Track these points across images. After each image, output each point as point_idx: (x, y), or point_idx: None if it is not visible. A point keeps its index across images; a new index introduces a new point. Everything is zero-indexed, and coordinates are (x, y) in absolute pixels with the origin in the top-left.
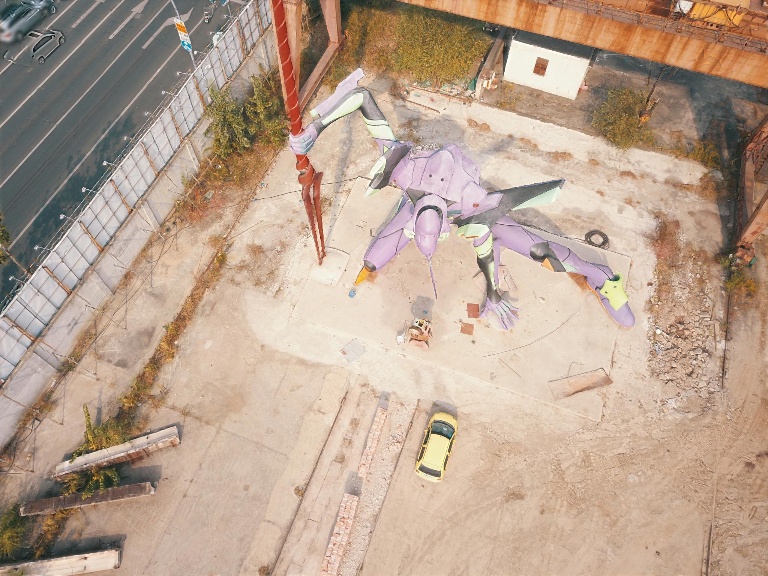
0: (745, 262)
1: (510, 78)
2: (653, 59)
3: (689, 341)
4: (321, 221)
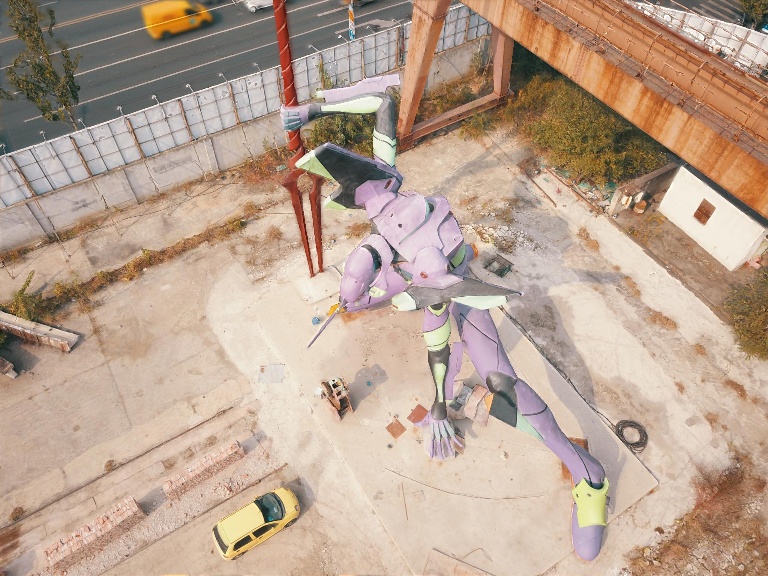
0: None
1: (666, 211)
2: None
3: None
4: (319, 228)
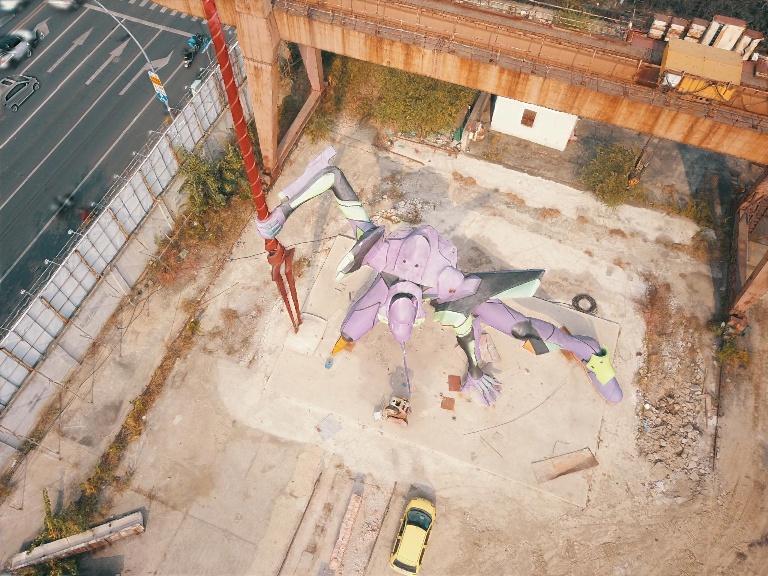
0: (738, 331)
1: (497, 128)
2: (640, 130)
3: (679, 417)
4: (295, 293)
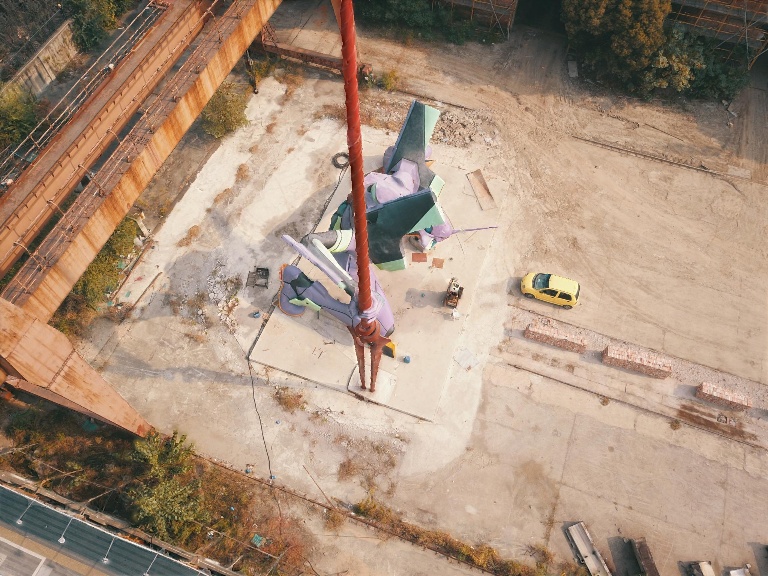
0: None
1: None
2: (258, 31)
3: None
4: None
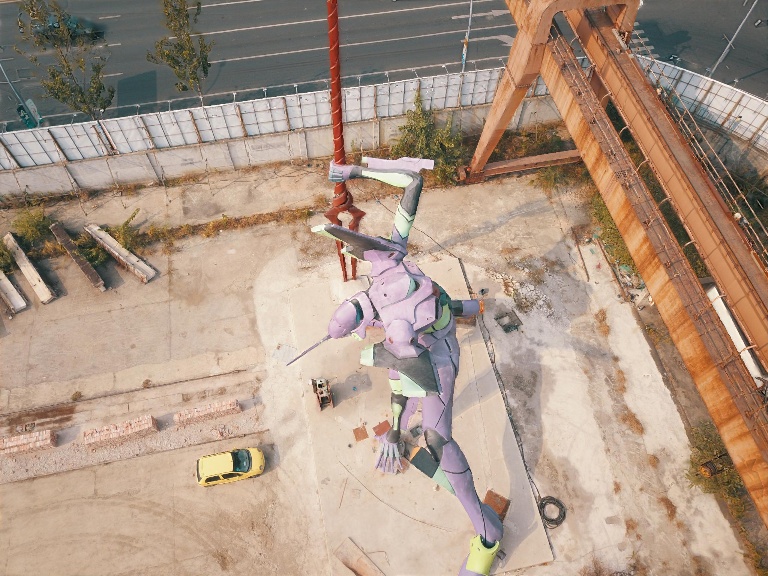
0: None
1: None
2: (712, 415)
3: None
4: None
